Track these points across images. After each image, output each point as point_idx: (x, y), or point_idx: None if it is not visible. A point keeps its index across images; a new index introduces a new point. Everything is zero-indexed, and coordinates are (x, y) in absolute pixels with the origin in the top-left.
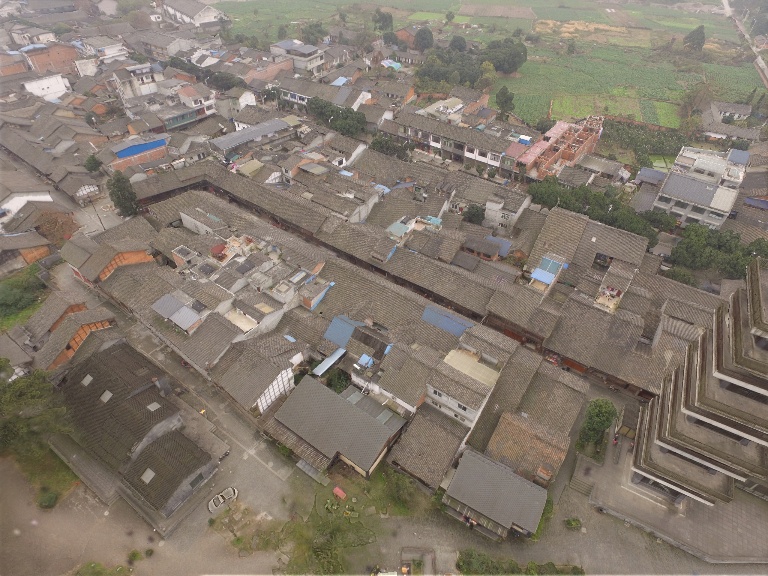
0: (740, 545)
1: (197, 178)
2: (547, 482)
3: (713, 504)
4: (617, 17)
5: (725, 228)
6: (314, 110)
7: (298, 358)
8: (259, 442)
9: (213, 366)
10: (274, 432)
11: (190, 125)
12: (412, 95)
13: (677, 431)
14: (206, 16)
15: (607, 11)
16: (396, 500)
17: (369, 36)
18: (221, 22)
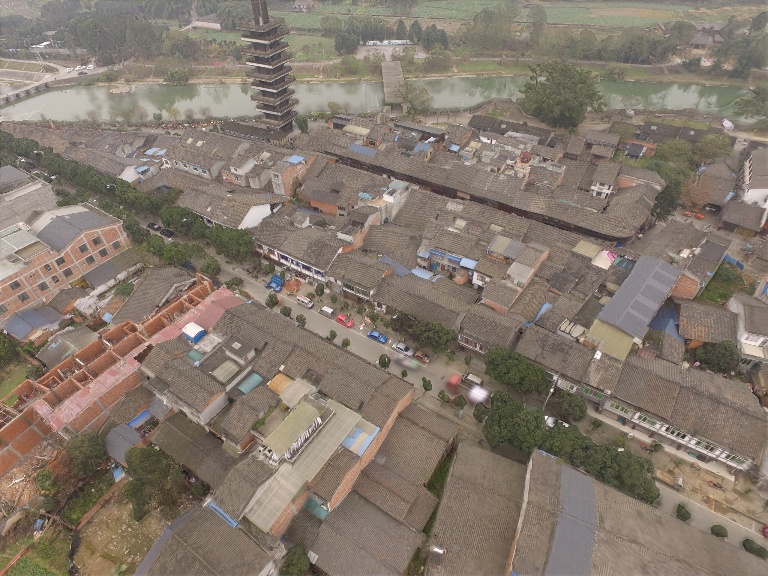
0: None
1: None
2: None
3: None
4: None
5: None
6: None
7: None
8: None
9: None
10: None
11: None
12: None
13: None
14: None
15: None
16: None
17: None
18: None
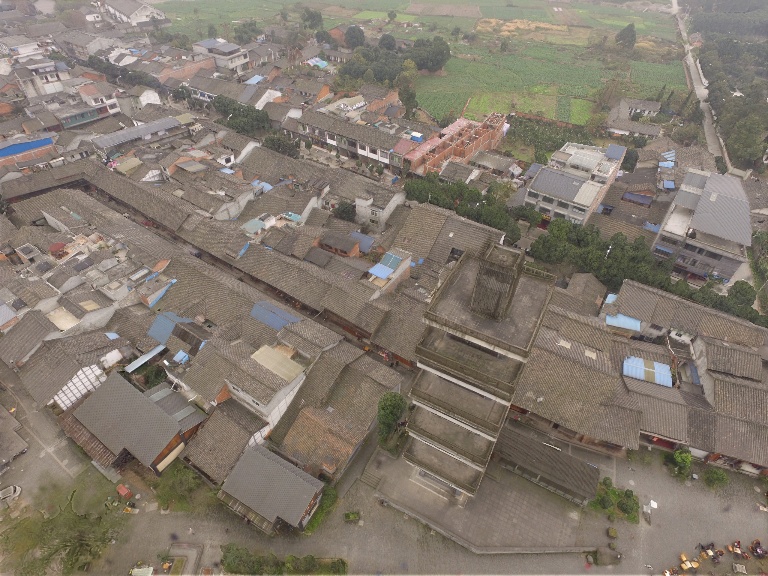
0: (510, 535)
1: (74, 176)
2: (332, 476)
3: (472, 495)
4: (562, 16)
5: (592, 223)
6: (218, 108)
7: (115, 355)
8: (61, 440)
9: (23, 364)
10: (69, 430)
11: None
12: (327, 93)
13: (410, 422)
14: (143, 15)
15: (554, 10)
16: (180, 496)
17: (305, 35)
18: (153, 21)
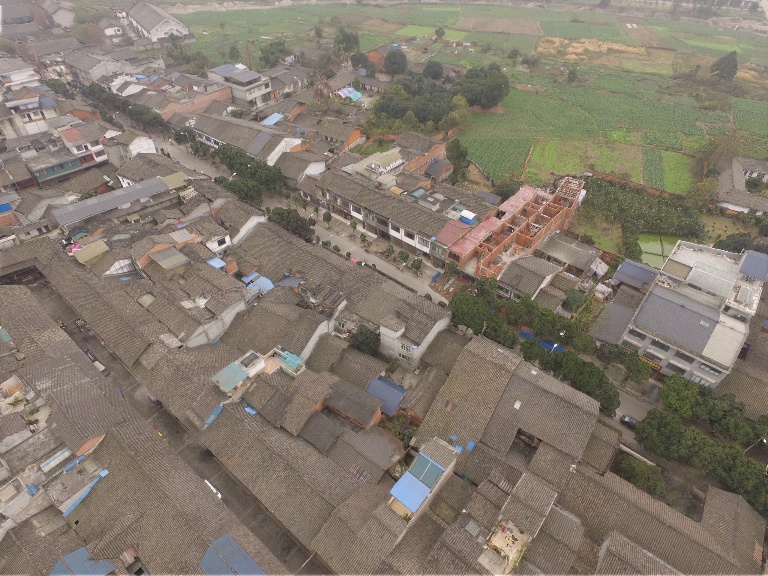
0: None
1: (24, 263)
2: None
3: None
4: (638, 34)
5: (725, 382)
6: (222, 160)
7: None
8: None
9: None
10: None
11: (73, 175)
12: (358, 138)
13: None
14: (164, 30)
15: (627, 27)
16: None
17: (339, 56)
18: (172, 39)
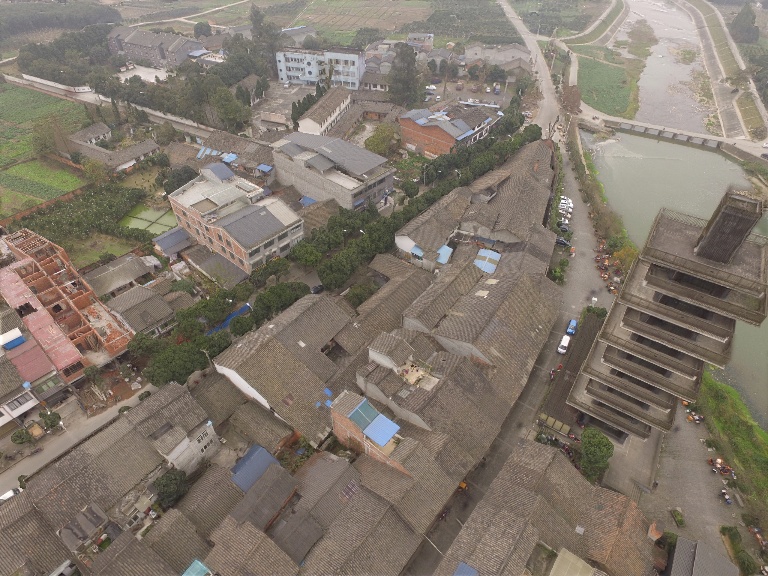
0: None
1: None
2: None
3: None
4: None
5: None
6: None
7: None
8: None
9: None
10: None
11: None
12: None
13: (698, 393)
14: None
15: None
16: None
17: None
18: None
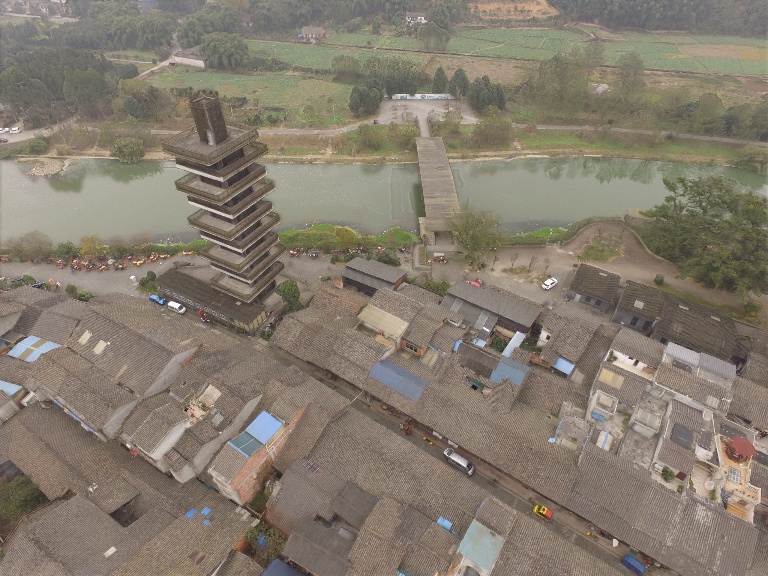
0: None
1: None
2: None
3: None
4: None
5: None
6: None
7: None
8: None
9: None
10: (536, 304)
11: None
12: None
13: None
14: None
15: None
16: None
17: None
18: None
